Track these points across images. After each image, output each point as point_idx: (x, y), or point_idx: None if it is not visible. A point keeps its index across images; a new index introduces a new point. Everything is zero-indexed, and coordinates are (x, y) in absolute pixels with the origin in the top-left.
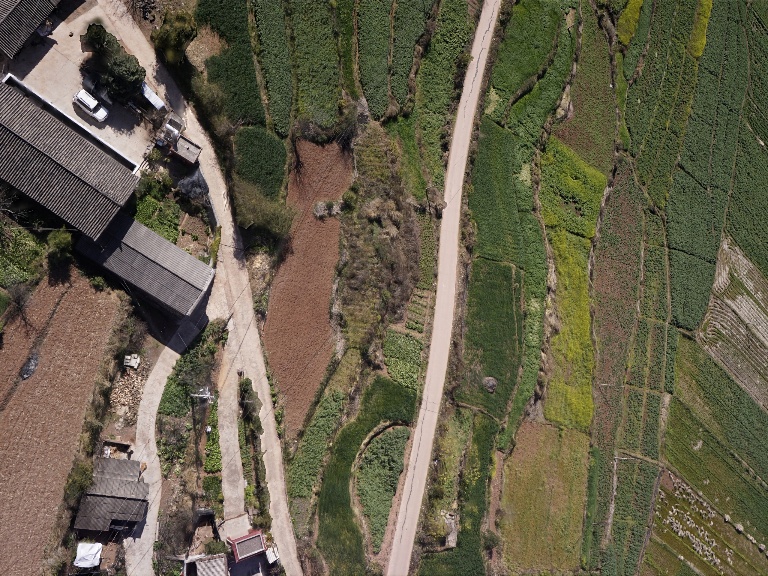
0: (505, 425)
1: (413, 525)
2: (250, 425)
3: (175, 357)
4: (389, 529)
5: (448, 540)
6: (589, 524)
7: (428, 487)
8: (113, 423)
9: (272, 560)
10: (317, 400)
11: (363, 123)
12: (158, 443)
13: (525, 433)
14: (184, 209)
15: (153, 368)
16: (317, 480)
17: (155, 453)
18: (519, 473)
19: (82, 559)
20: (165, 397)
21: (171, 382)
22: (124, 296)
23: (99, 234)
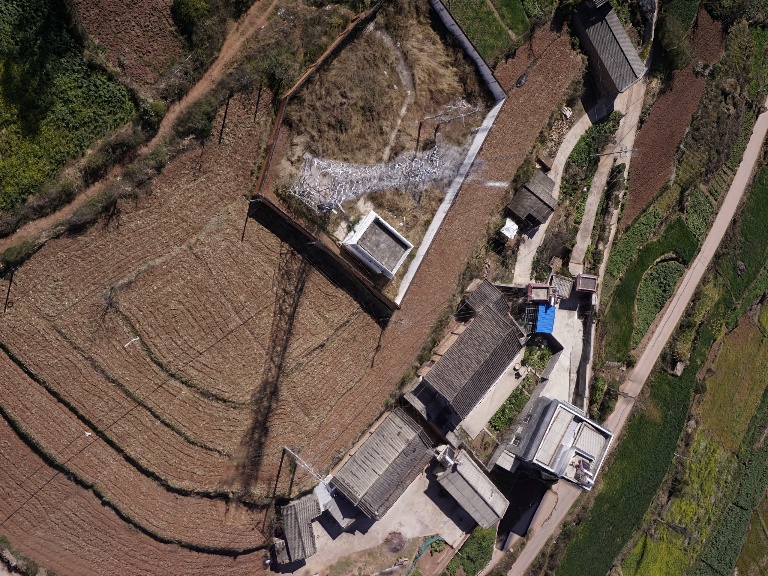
0: (738, 306)
1: (664, 341)
2: (613, 199)
3: (589, 124)
4: (647, 335)
5: (677, 368)
6: (754, 423)
7: (682, 318)
8: (543, 150)
9: (593, 303)
10: (645, 209)
11: (740, 17)
12: (563, 178)
13: (743, 323)
14: (631, 19)
15: (575, 124)
16: (624, 269)
17: (559, 184)
18: (728, 352)
19: (507, 229)
20: (576, 148)
21: (583, 140)
22: (586, 60)
23: (602, 4)
